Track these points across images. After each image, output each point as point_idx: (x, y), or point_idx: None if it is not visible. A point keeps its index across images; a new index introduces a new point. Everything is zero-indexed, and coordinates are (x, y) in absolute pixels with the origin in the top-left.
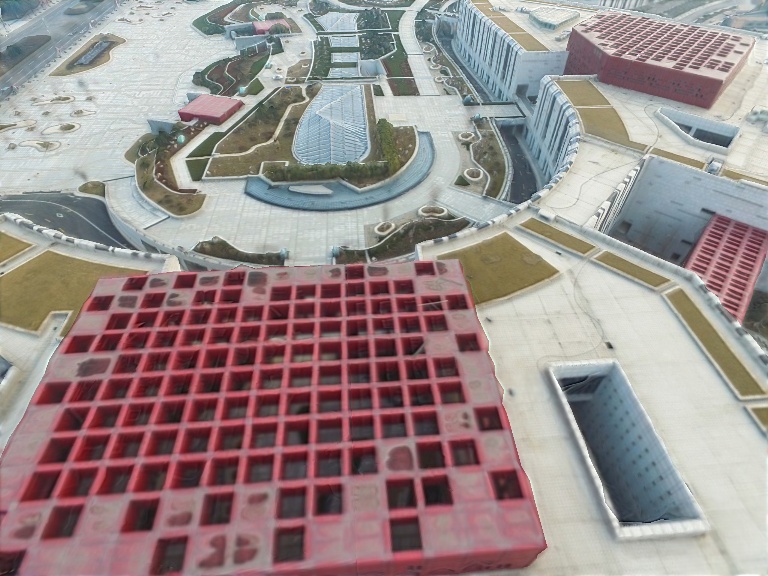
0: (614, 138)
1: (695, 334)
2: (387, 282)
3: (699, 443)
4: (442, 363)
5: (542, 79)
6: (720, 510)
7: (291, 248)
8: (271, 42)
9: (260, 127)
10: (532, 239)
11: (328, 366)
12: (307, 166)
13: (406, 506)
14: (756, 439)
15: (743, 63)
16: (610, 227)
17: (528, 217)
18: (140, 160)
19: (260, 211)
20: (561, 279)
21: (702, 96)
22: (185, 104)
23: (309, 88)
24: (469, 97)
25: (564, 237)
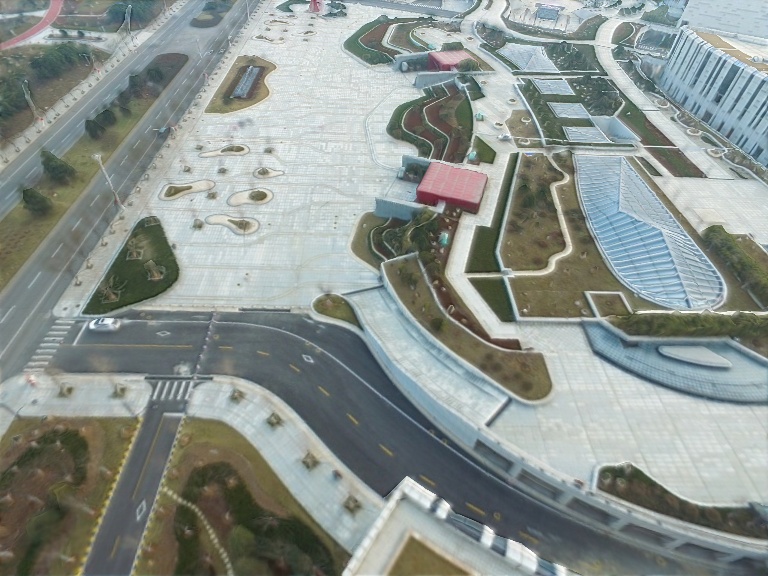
0: None
1: None
2: None
3: None
4: None
5: None
6: None
7: (752, 493)
8: (465, 82)
9: None
10: None
11: None
12: (685, 317)
13: None
14: None
15: None
16: None
17: None
18: (390, 266)
19: (643, 396)
20: None
21: None
22: (401, 170)
23: (559, 158)
24: None
25: None
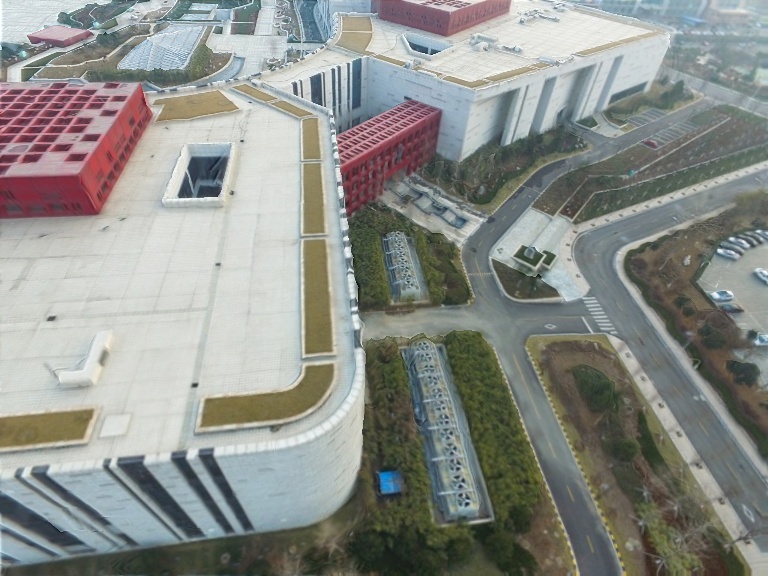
0: (353, 48)
1: (303, 136)
2: (79, 90)
3: (258, 177)
4: (83, 120)
5: (333, 15)
6: (242, 199)
7: None
8: None
9: (98, 49)
10: (238, 96)
11: (4, 119)
12: (118, 70)
13: (7, 162)
14: (295, 176)
15: (502, 11)
16: (346, 115)
17: (243, 84)
18: None
19: None
20: (238, 113)
21: (441, 26)
22: None
23: (157, 26)
24: (291, 36)
25: (259, 94)
